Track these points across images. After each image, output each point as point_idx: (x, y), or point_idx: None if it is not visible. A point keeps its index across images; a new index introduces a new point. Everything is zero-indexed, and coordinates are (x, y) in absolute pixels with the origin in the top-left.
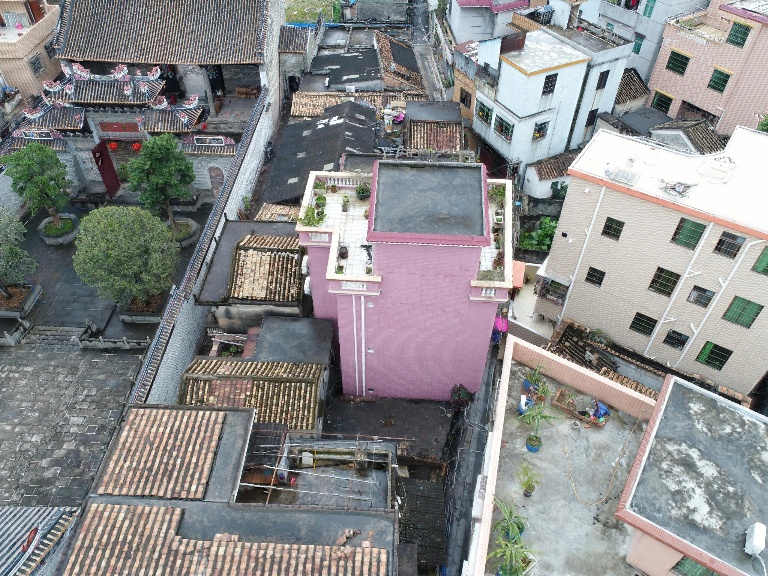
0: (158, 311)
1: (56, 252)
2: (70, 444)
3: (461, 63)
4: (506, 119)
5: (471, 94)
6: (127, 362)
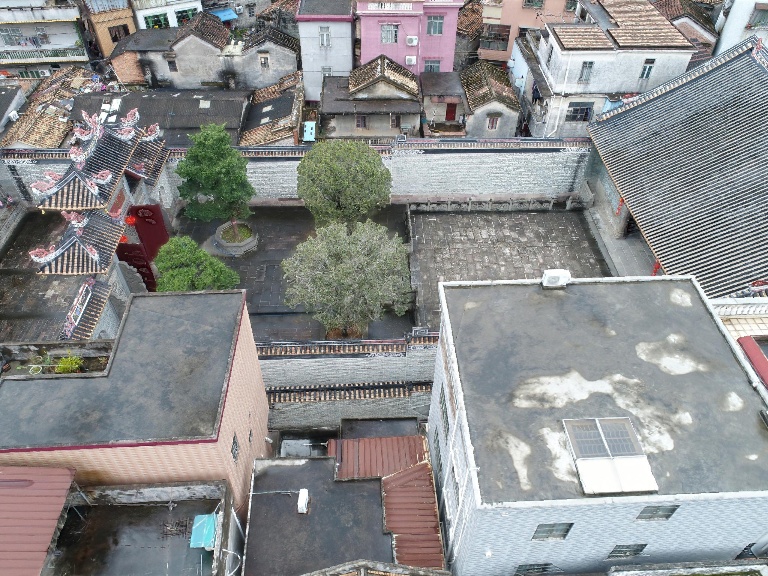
0: (361, 219)
1: (254, 336)
2: (505, 232)
3: (102, 3)
4: (188, 8)
5: (126, 23)
6: (423, 223)
